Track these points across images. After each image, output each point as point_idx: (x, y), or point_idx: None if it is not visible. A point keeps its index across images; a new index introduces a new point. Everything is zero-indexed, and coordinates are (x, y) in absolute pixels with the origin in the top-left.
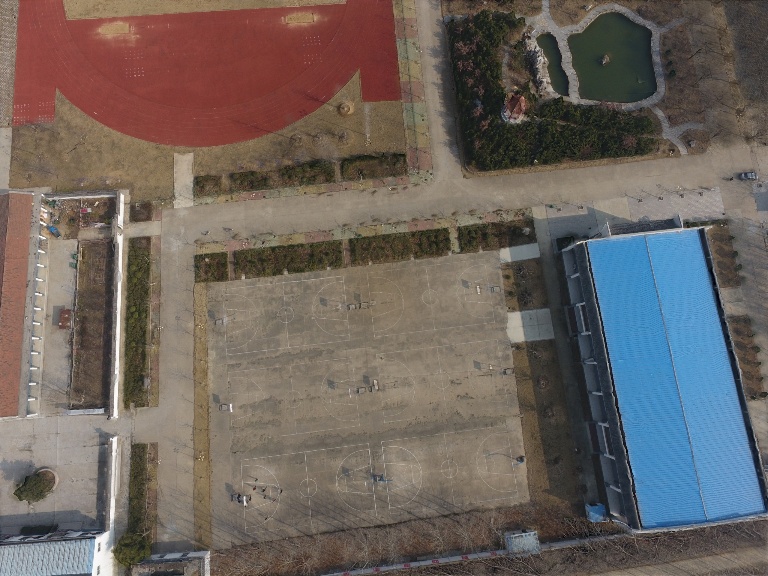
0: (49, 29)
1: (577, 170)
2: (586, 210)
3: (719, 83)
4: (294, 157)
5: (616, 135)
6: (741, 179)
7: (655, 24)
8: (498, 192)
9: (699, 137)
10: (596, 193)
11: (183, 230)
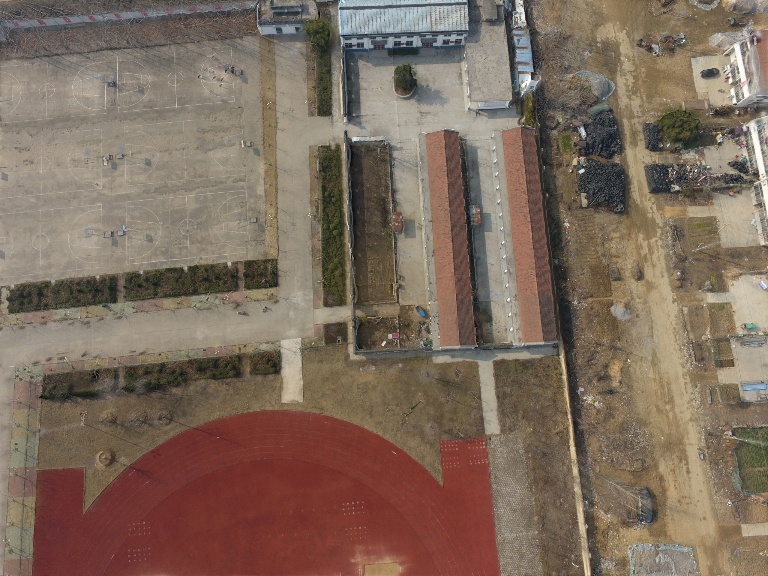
0: (462, 570)
1: None
2: None
3: None
4: (169, 397)
5: None
6: None
7: None
8: None
9: None
10: None
11: (291, 314)
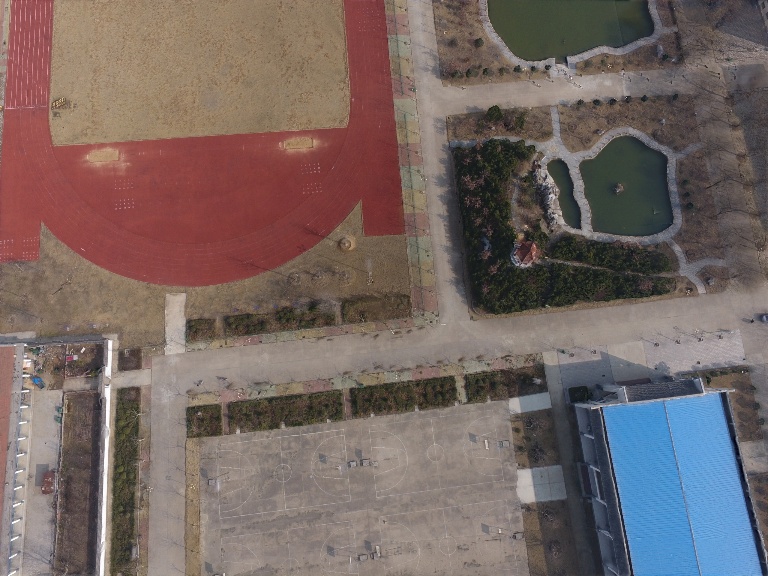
0: (34, 156)
1: (590, 311)
2: (600, 355)
3: (738, 214)
4: (292, 298)
5: (632, 278)
6: (762, 321)
7: (671, 149)
8: (507, 336)
9: (718, 274)
10: (610, 336)
11: (174, 379)
